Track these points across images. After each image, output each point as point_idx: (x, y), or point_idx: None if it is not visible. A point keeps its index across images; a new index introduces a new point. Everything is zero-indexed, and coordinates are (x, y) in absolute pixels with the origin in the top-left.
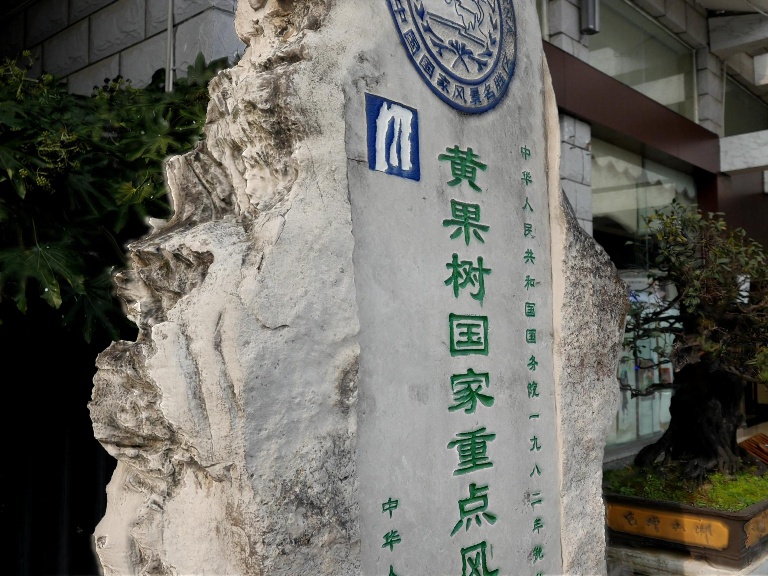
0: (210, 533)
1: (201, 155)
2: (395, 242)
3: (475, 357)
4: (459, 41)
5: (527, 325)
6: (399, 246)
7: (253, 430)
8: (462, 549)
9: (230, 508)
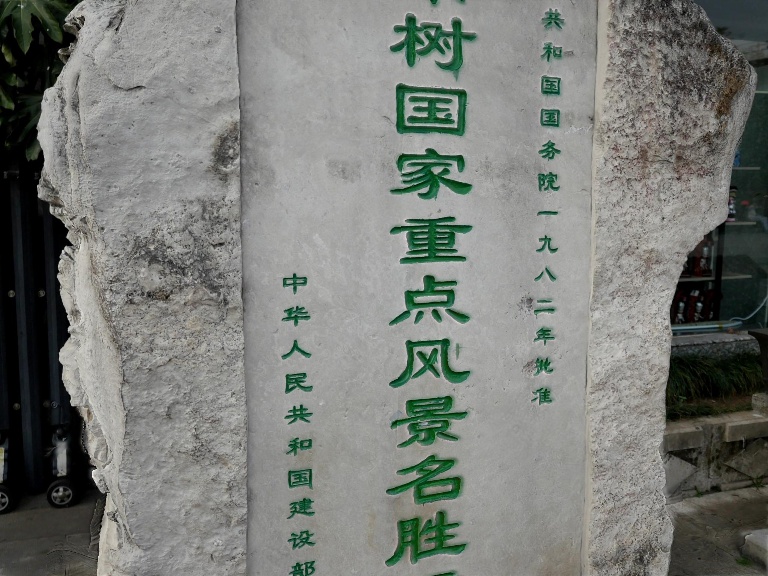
0: (88, 281)
1: None
2: (310, 0)
3: (440, 136)
4: None
5: (542, 104)
6: (316, 5)
7: (101, 186)
8: (409, 341)
9: (91, 258)
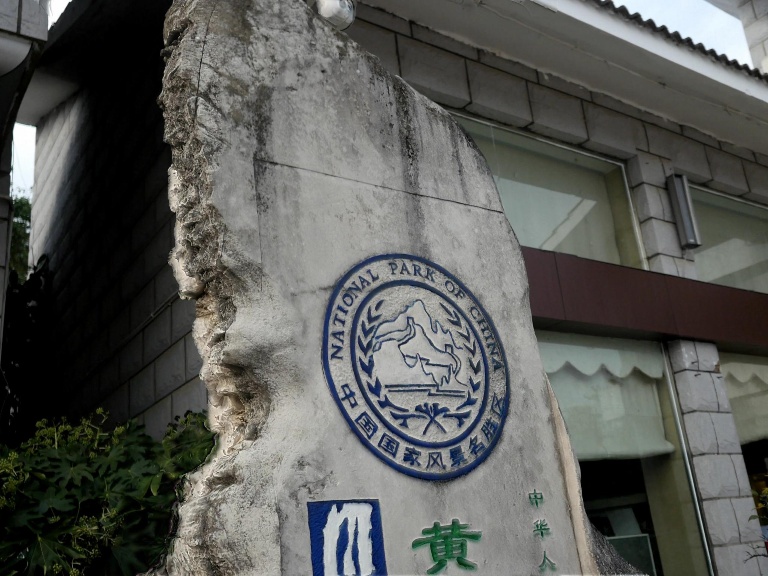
0: None
1: None
2: None
3: None
4: (430, 402)
5: None
6: None
7: None
8: None
9: None
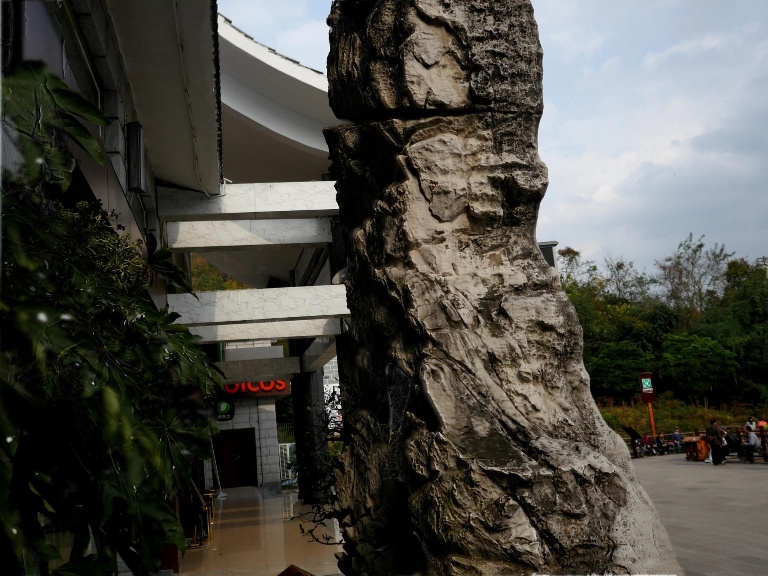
0: None
1: (458, 365)
2: None
3: None
4: None
5: None
6: None
7: None
8: None
9: None
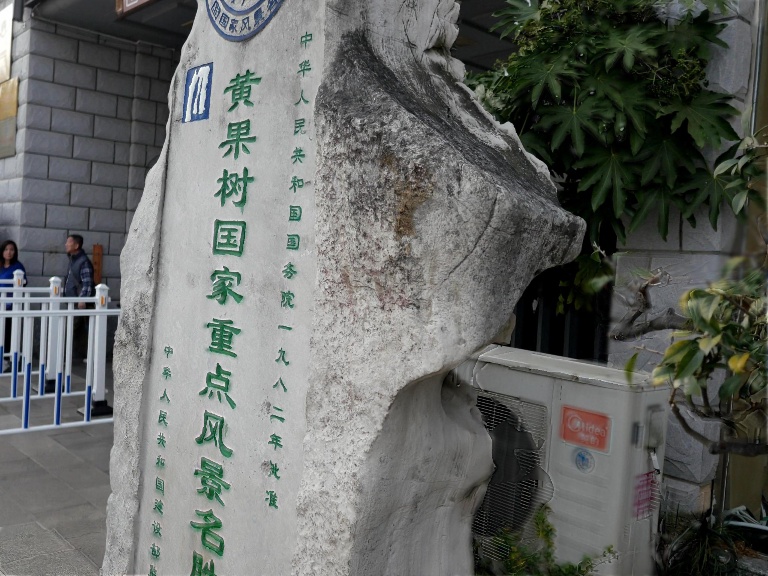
0: None
1: None
2: None
3: None
4: None
5: (287, 230)
6: (192, 172)
7: None
8: None
9: None
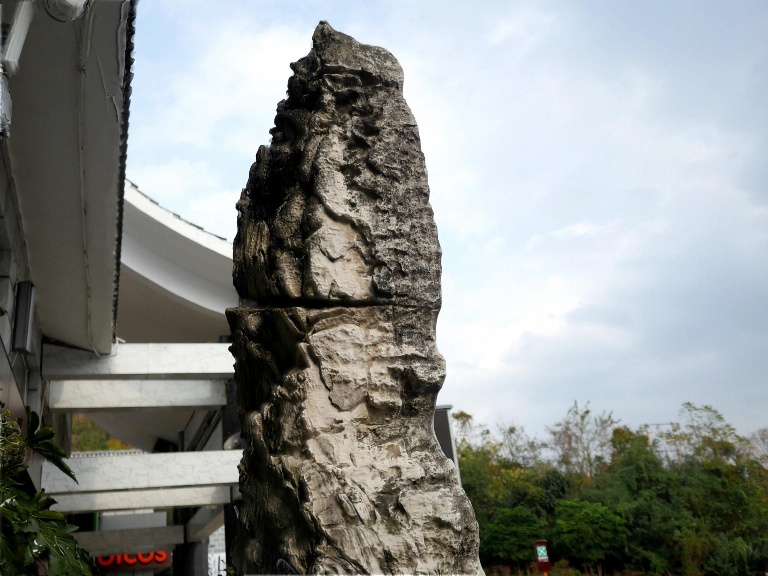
0: None
1: (353, 565)
2: None
3: None
4: None
5: None
6: None
7: None
8: None
9: None
